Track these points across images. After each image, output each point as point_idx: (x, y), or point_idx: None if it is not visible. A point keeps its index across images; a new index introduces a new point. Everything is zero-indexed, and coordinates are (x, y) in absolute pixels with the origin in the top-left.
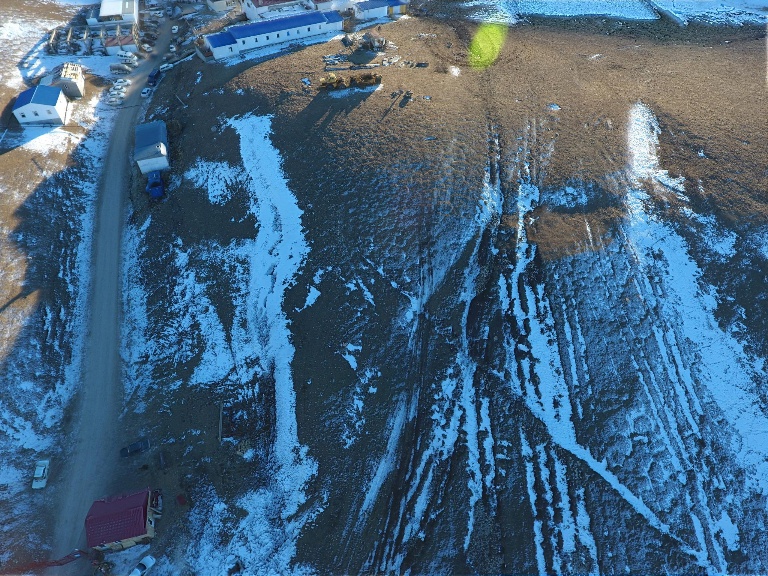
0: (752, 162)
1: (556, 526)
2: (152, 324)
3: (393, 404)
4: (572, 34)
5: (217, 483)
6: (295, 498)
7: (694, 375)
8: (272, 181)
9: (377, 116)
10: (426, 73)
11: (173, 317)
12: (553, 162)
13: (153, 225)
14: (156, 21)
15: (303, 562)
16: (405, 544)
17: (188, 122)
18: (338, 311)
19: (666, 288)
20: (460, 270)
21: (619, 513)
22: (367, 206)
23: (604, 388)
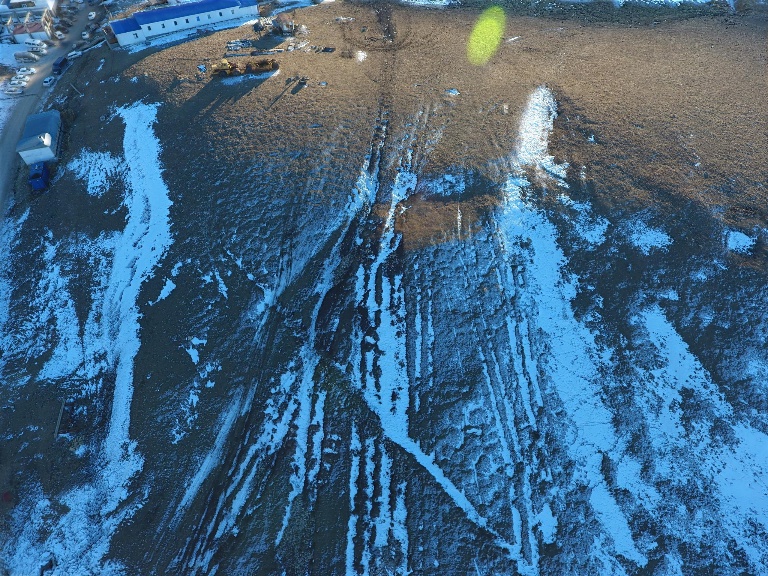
0: (641, 147)
1: (371, 520)
2: (12, 319)
3: (228, 398)
4: (498, 16)
5: (45, 480)
6: (117, 494)
7: (540, 366)
8: (148, 171)
9: (265, 103)
10: (330, 58)
11: (33, 312)
12: (438, 149)
13: (30, 218)
14: (74, 7)
15: (114, 559)
16: (217, 540)
17: (80, 111)
18: (189, 304)
19: (528, 277)
20: (320, 261)
21: (438, 507)
22: (236, 196)
23: (446, 380)
